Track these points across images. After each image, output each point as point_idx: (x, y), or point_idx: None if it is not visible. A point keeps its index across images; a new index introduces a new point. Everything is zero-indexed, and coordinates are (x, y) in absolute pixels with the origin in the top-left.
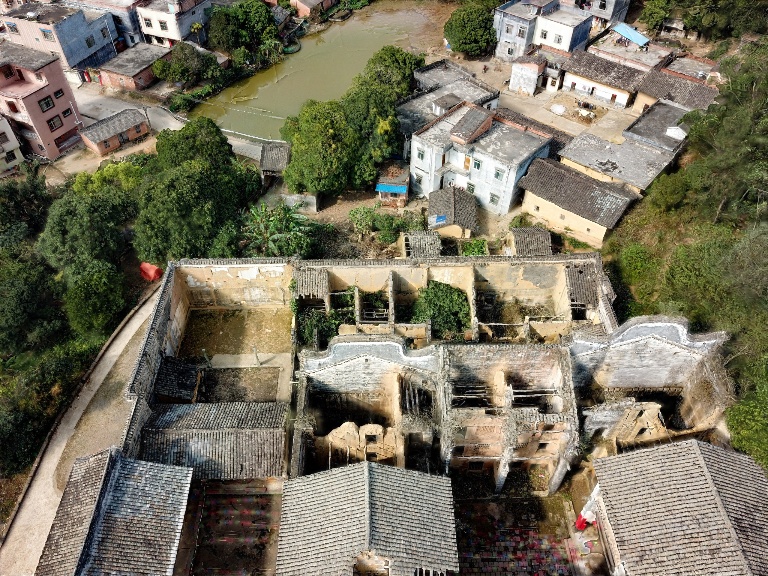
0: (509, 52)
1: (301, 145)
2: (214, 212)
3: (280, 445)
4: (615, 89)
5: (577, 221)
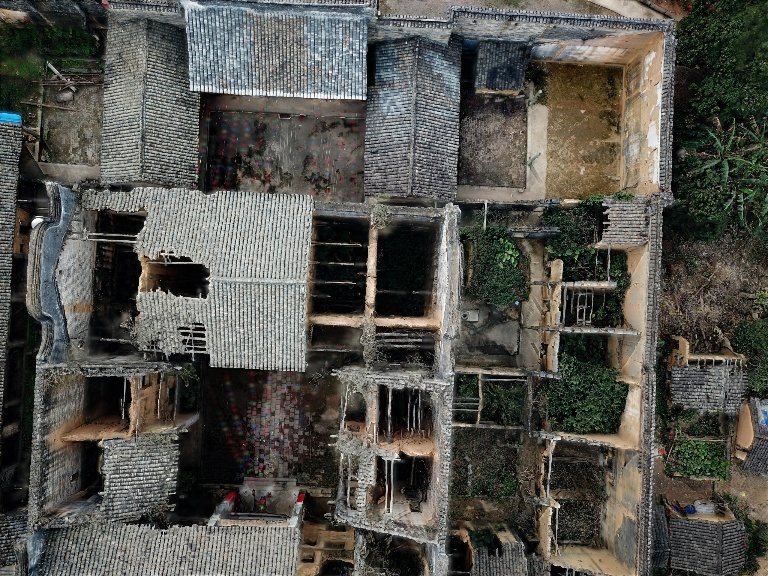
0: None
1: None
2: None
3: (394, 192)
4: None
5: None
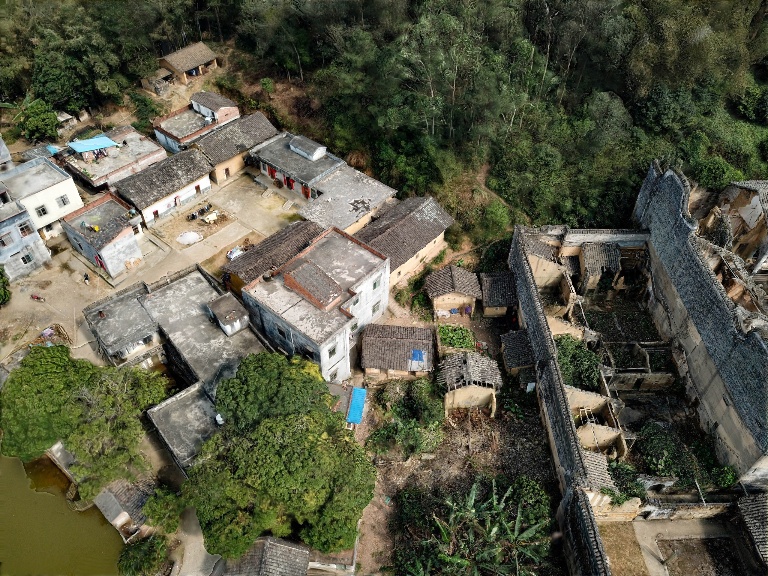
0: (25, 261)
1: (318, 496)
2: None
3: None
4: (195, 181)
5: (427, 246)
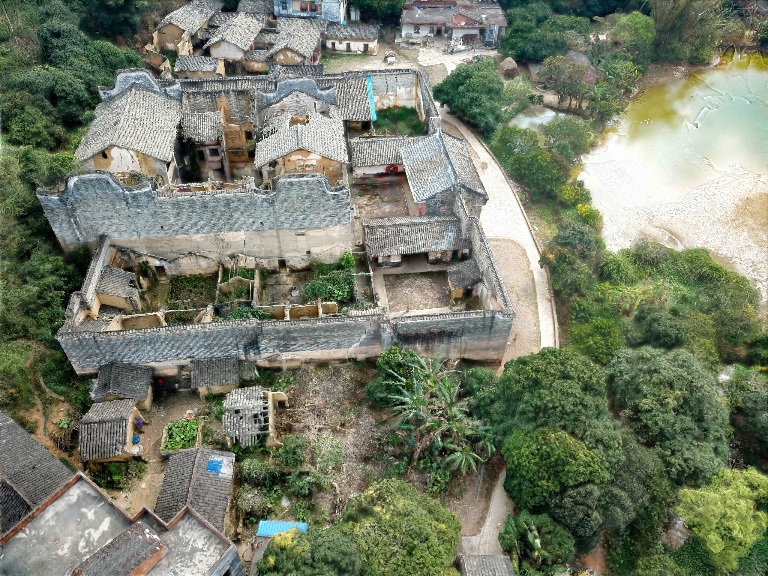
0: None
1: None
2: (503, 376)
3: None
4: None
5: None
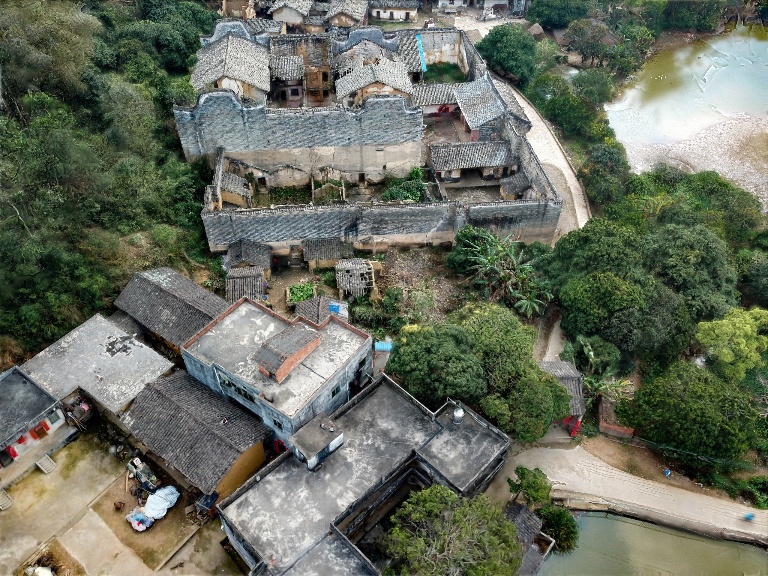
0: None
1: None
2: (558, 241)
3: None
4: None
5: None
